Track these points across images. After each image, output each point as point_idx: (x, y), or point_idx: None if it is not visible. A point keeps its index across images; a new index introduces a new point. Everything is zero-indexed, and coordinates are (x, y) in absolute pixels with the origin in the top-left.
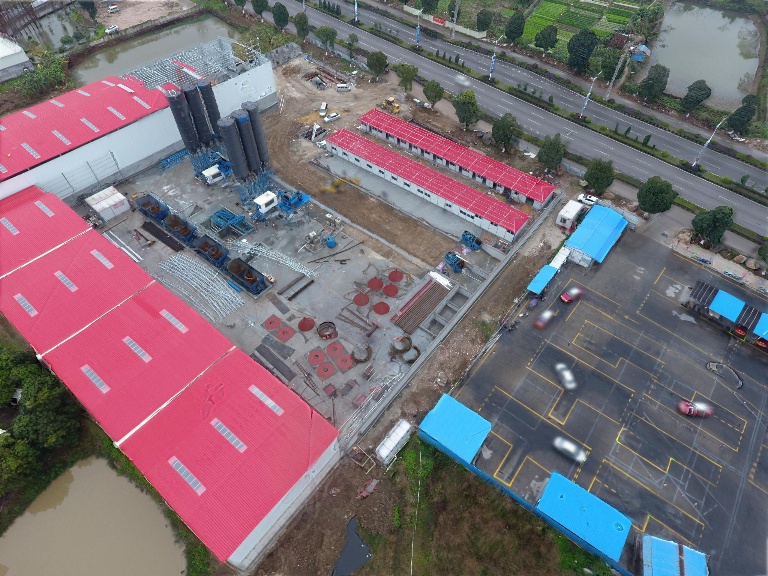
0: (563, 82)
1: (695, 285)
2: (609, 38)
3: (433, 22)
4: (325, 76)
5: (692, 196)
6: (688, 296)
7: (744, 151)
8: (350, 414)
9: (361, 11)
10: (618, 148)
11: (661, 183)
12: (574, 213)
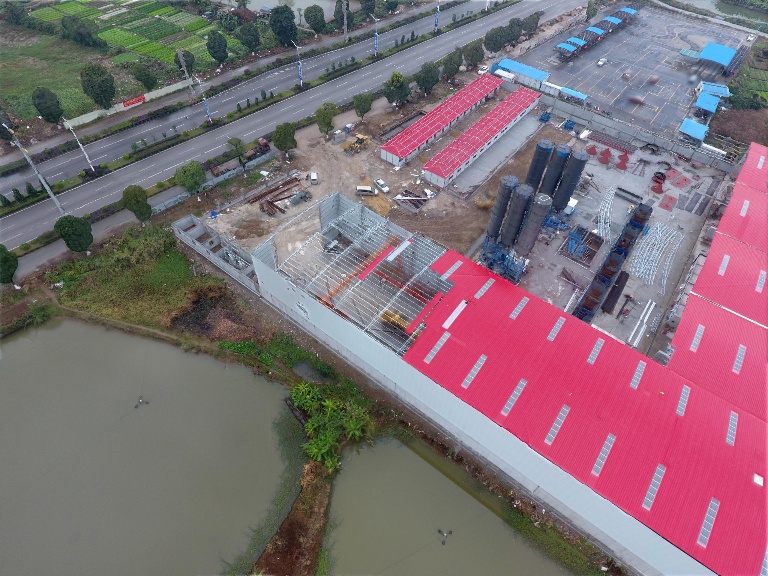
0: (312, 53)
1: (557, 51)
2: (236, 17)
3: (126, 109)
4: (274, 196)
5: (465, 40)
6: (555, 60)
7: (411, 15)
8: (705, 170)
9: (40, 169)
10: (414, 51)
11: (501, 29)
12: (509, 73)
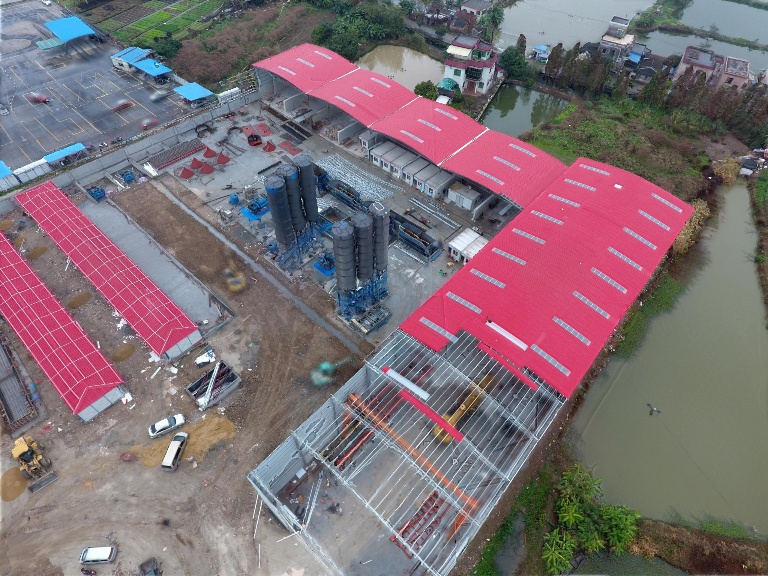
0: None
1: None
2: None
3: None
4: None
5: None
6: None
7: None
8: (251, 110)
9: None
10: None
11: None
12: None
